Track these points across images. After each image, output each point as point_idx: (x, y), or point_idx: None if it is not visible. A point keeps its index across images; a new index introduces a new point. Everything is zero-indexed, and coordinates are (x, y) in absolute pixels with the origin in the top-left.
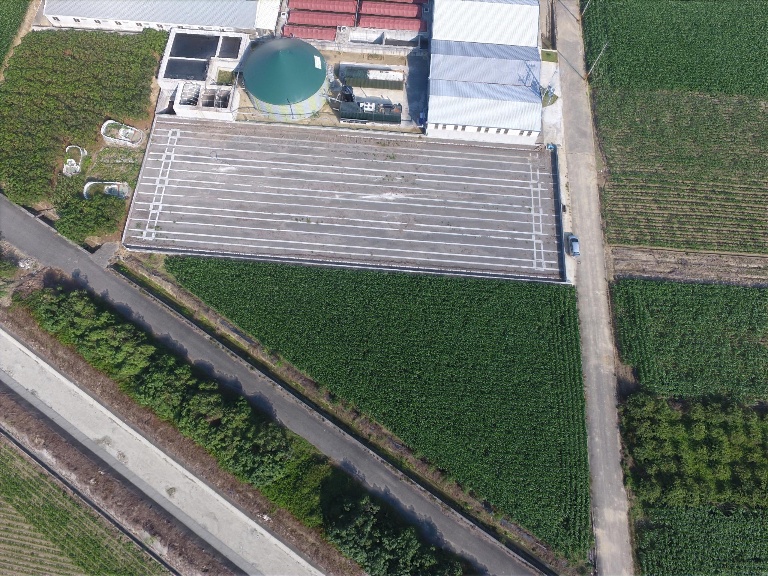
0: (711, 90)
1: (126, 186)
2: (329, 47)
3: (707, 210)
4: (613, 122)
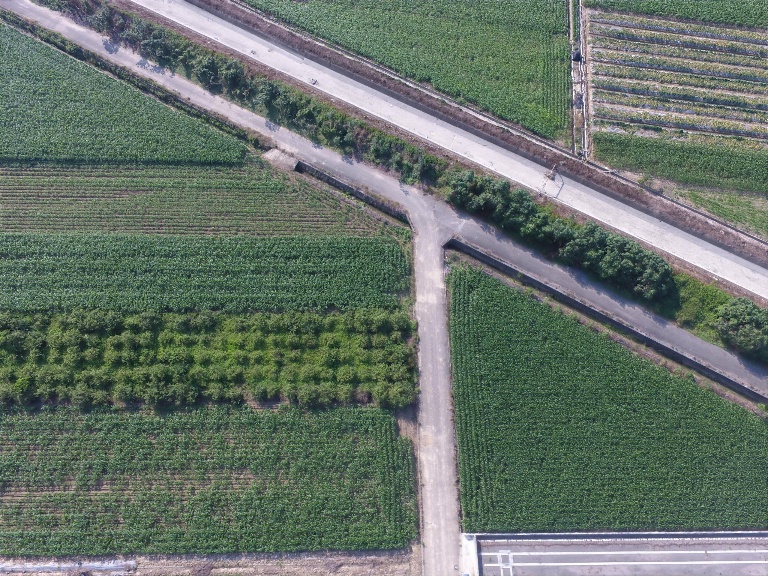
0: None
1: None
2: None
3: None
4: None
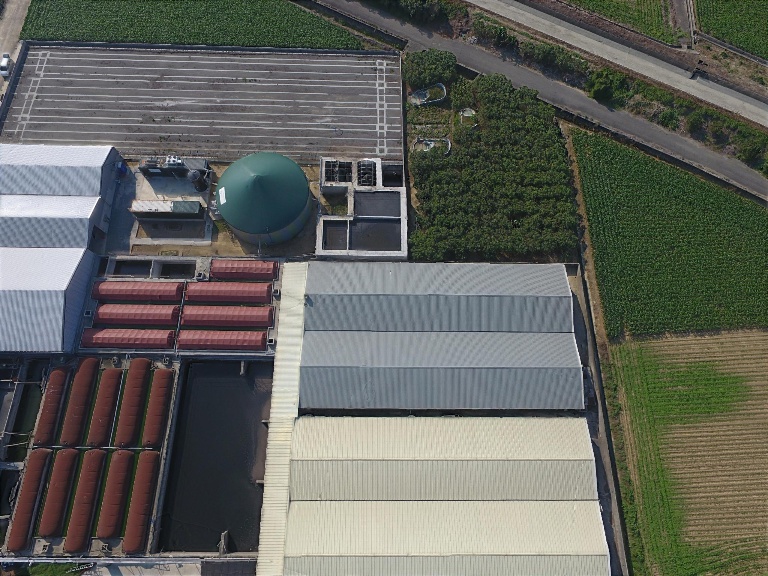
0: None
1: None
2: None
3: None
4: None
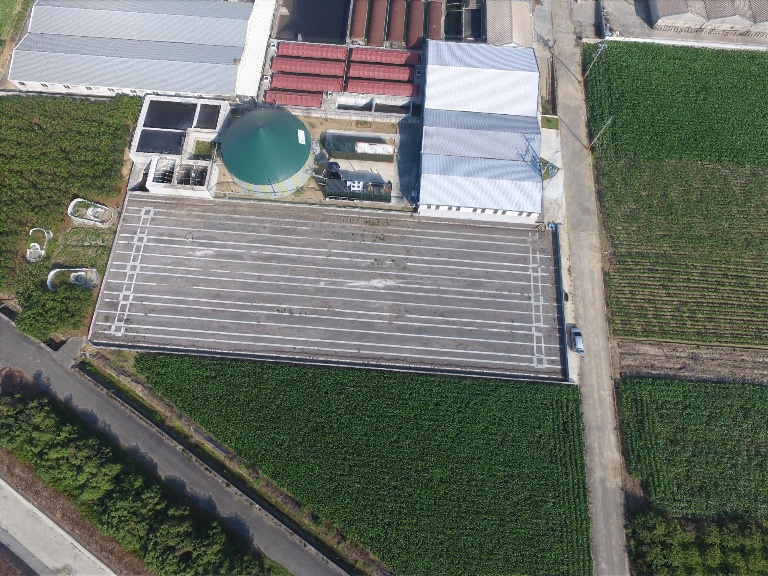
0: (722, 161)
1: (94, 273)
2: (315, 114)
3: (719, 296)
4: (618, 197)
